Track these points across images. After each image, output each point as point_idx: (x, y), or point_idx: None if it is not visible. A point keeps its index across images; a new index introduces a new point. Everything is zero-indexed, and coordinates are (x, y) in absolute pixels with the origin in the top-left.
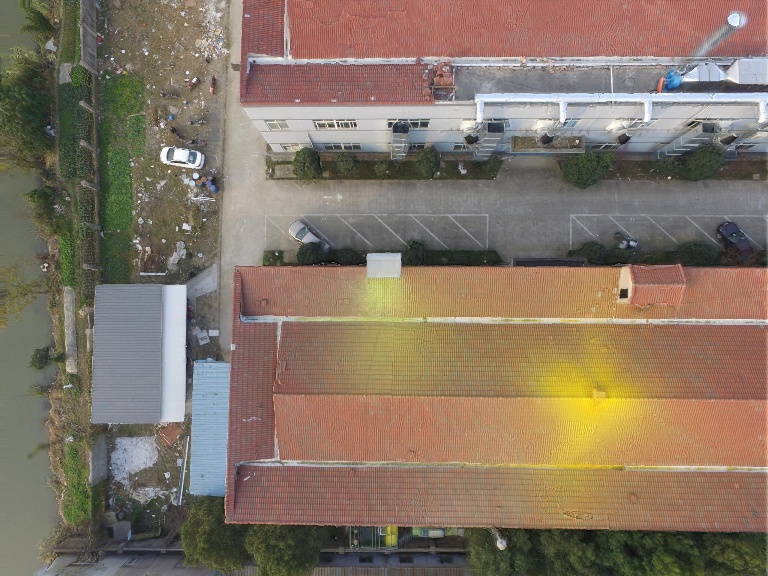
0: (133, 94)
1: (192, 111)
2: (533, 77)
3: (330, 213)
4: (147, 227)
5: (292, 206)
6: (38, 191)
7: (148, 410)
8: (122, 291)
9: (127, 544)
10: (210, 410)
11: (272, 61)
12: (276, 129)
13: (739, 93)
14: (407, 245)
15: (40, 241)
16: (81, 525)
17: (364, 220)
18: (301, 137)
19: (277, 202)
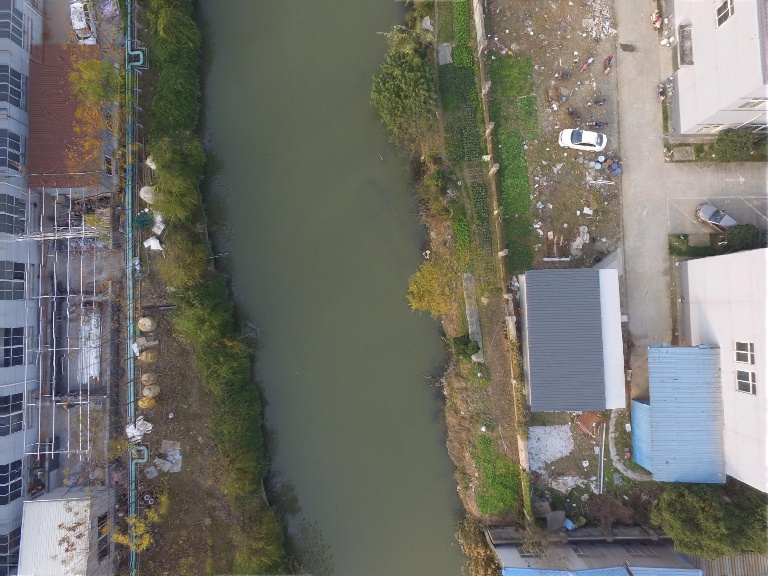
0: (521, 75)
1: (584, 92)
2: None
3: (734, 196)
4: (547, 211)
5: (694, 189)
6: (440, 175)
7: (594, 397)
8: (556, 276)
9: (568, 534)
10: (671, 395)
11: None
12: (740, 108)
13: None
14: None
15: (422, 227)
16: (501, 516)
17: None
18: (746, 117)
19: (678, 185)
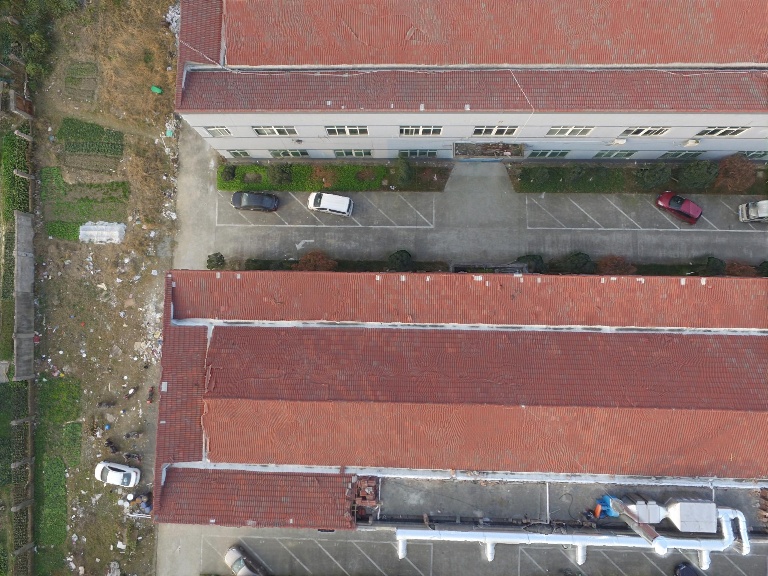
0: (70, 399)
1: (129, 419)
2: (464, 490)
3: (268, 536)
4: (81, 544)
5: None
6: None
7: None
8: None
9: None
10: None
11: (190, 463)
12: None
13: (680, 540)
14: (347, 574)
15: None
16: None
17: (303, 545)
18: None
19: None
